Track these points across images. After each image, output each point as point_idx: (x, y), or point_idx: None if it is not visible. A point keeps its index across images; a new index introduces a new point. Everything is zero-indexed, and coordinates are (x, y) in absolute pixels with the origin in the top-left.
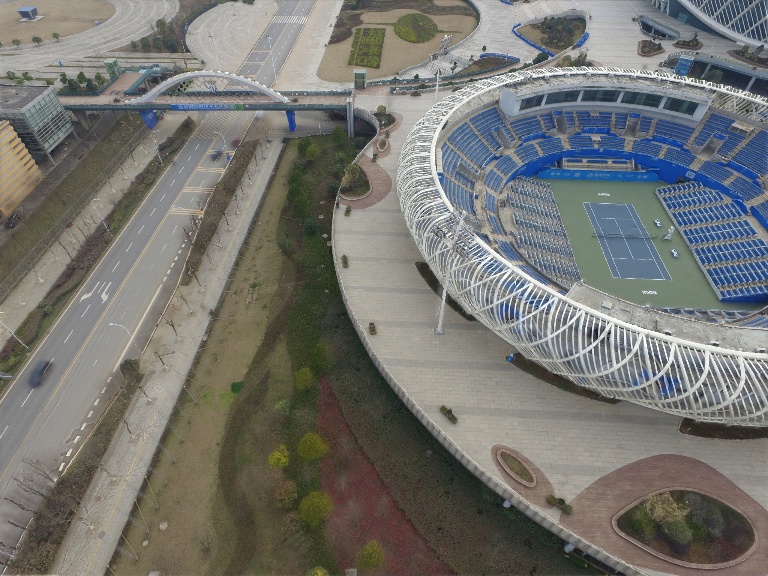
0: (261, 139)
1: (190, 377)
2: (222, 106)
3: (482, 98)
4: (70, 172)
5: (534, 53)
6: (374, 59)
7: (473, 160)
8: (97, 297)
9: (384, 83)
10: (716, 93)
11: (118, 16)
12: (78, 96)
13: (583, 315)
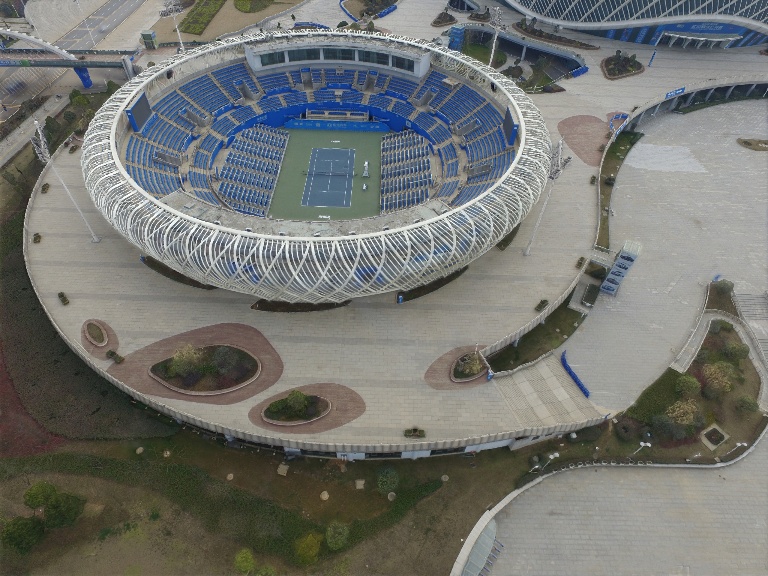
0: (54, 95)
1: None
2: (8, 62)
3: (238, 56)
4: None
5: (348, 23)
6: (200, 26)
7: (205, 108)
8: None
9: (177, 45)
10: (430, 52)
11: None
12: None
13: (159, 212)
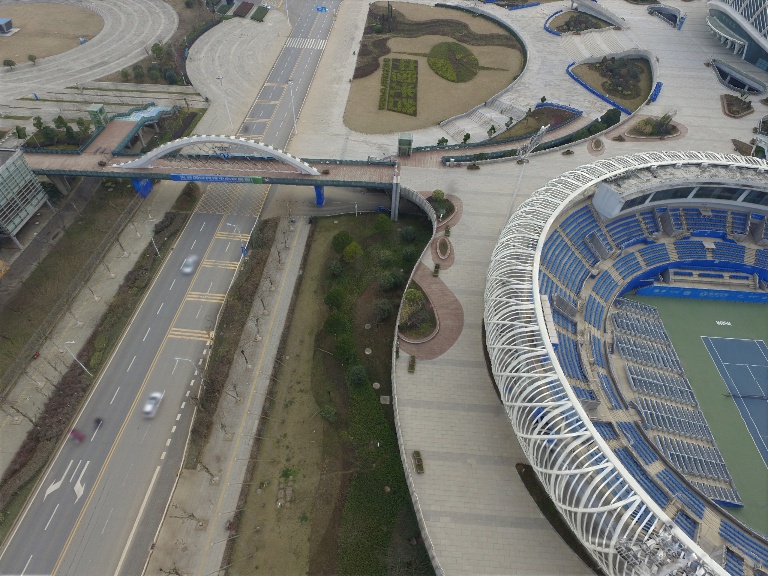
0: (282, 217)
1: None
2: (235, 179)
3: None
4: (41, 260)
5: (597, 103)
6: (409, 103)
7: (569, 285)
8: (69, 490)
9: (433, 148)
10: None
11: (107, 32)
12: (54, 154)
13: None
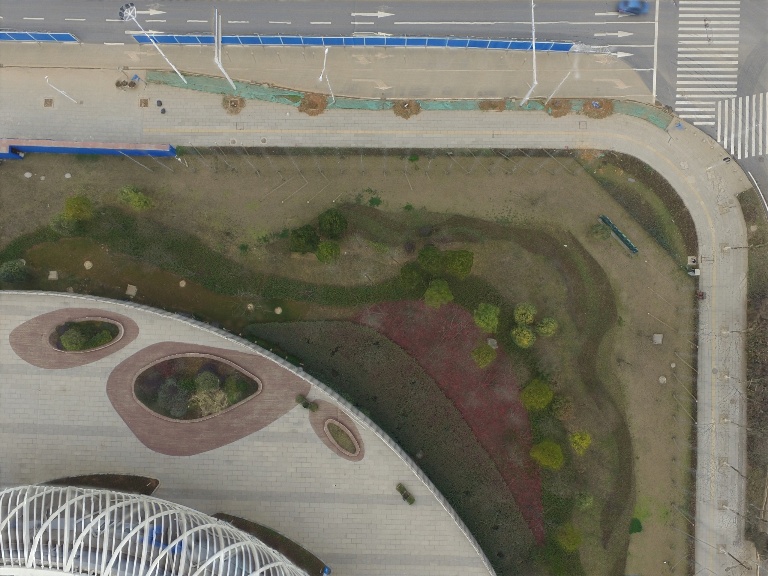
0: None
1: (691, 538)
2: None
3: None
4: None
5: None
6: None
7: None
8: None
9: None
10: None
11: None
12: None
13: None
